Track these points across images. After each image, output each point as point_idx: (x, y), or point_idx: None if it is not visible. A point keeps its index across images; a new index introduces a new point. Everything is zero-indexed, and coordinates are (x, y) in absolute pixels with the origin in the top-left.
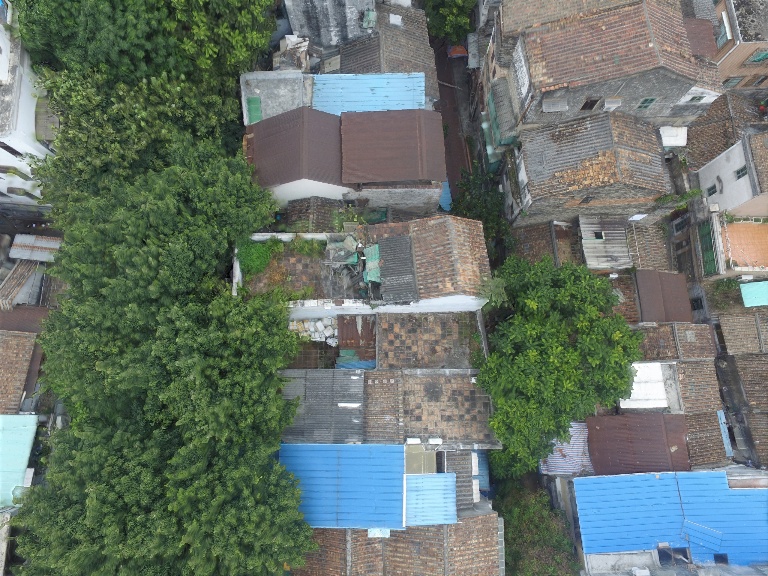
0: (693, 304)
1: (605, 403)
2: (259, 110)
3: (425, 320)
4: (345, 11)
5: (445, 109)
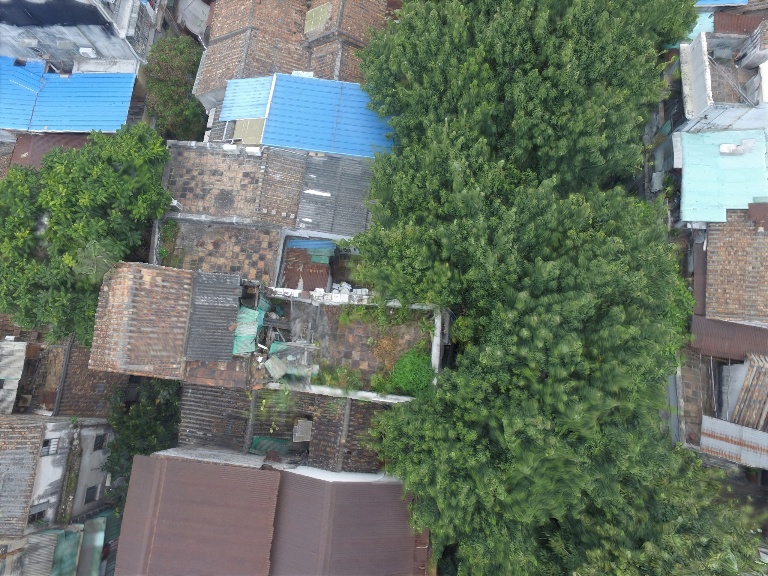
0: None
1: None
2: None
3: None
4: None
5: None
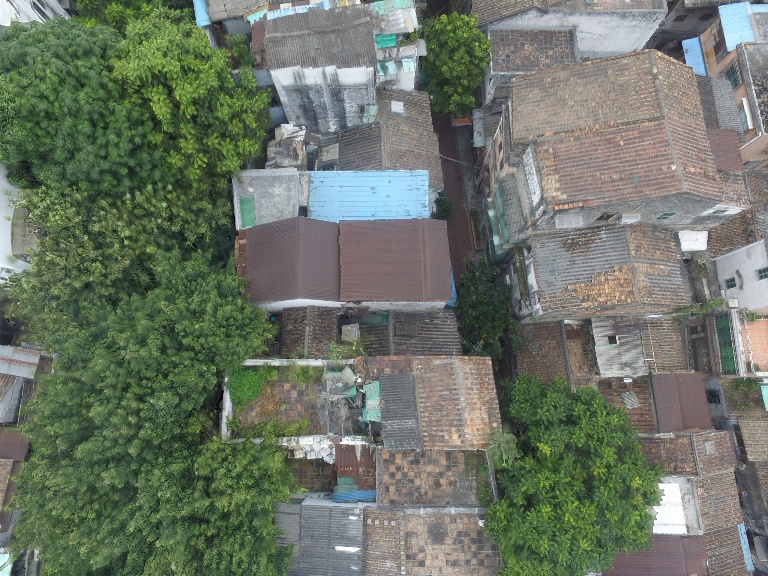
0: (709, 396)
1: (623, 549)
2: (252, 211)
3: (429, 449)
4: (344, 105)
5: (448, 179)
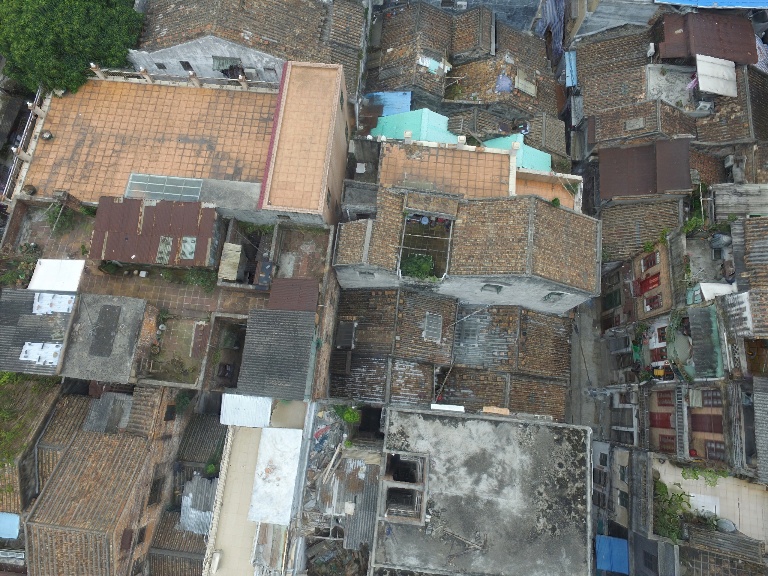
0: None
1: None
2: None
3: None
4: None
5: None
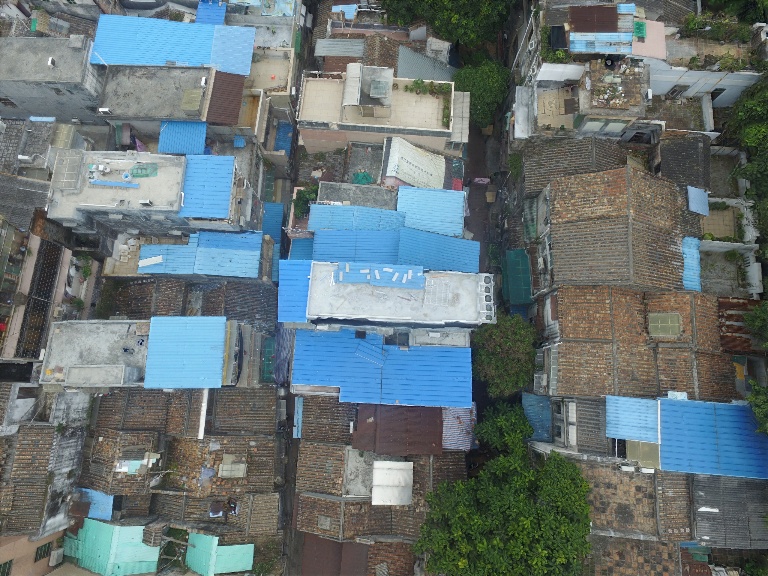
0: None
1: (465, 487)
2: None
3: None
4: None
5: None
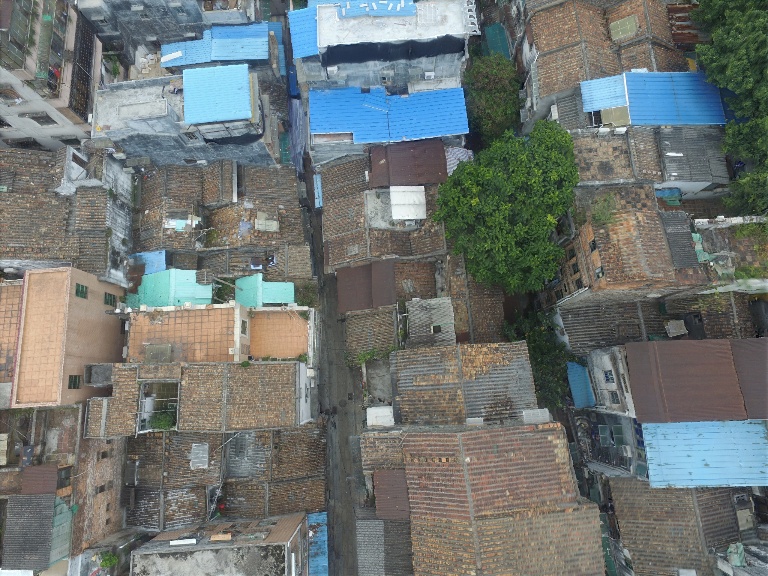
0: None
1: None
2: None
3: None
4: None
5: None
